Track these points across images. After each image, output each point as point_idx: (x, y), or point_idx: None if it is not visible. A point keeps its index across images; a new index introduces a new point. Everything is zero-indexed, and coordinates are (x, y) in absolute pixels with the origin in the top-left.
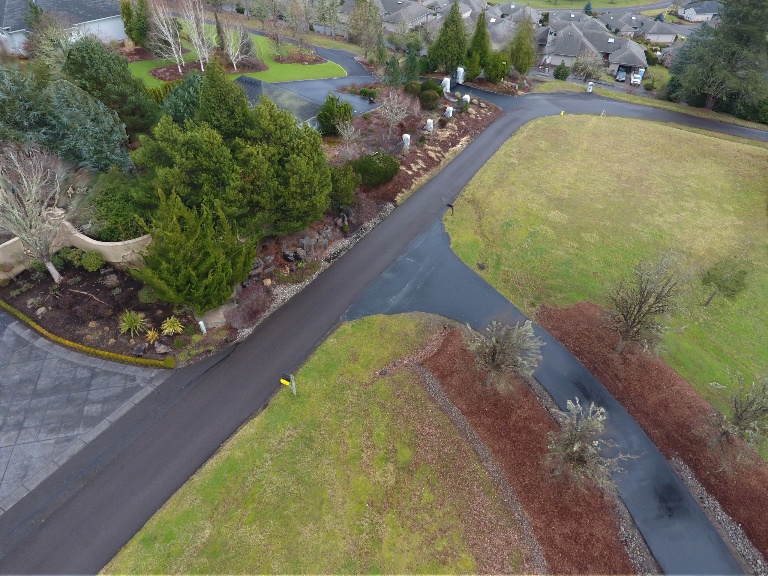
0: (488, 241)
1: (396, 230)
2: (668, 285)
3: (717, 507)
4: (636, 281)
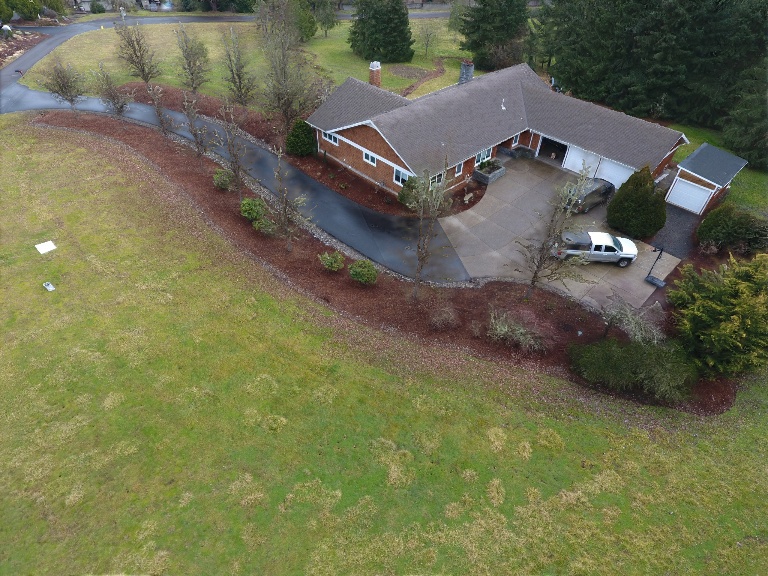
0: None
1: None
2: (136, 34)
3: (204, 116)
4: (122, 38)
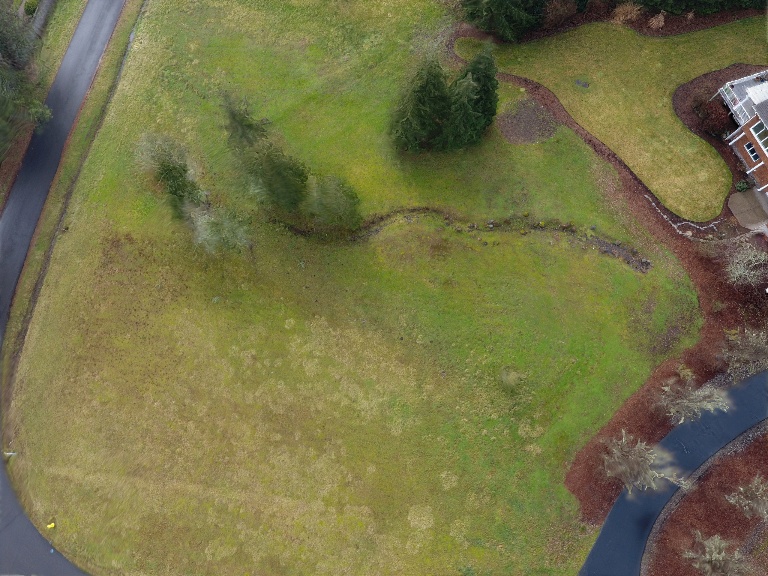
0: None
1: None
2: None
3: None
4: None
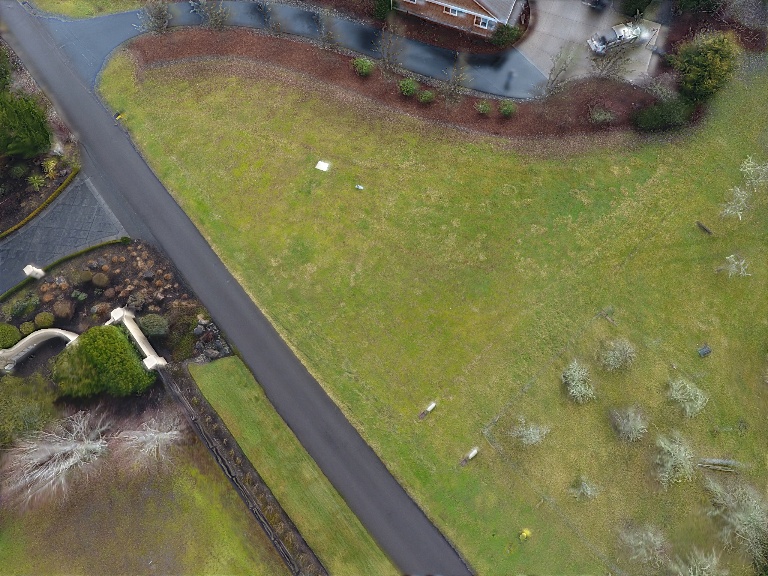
0: (71, 0)
1: (28, 45)
2: None
3: None
4: None
